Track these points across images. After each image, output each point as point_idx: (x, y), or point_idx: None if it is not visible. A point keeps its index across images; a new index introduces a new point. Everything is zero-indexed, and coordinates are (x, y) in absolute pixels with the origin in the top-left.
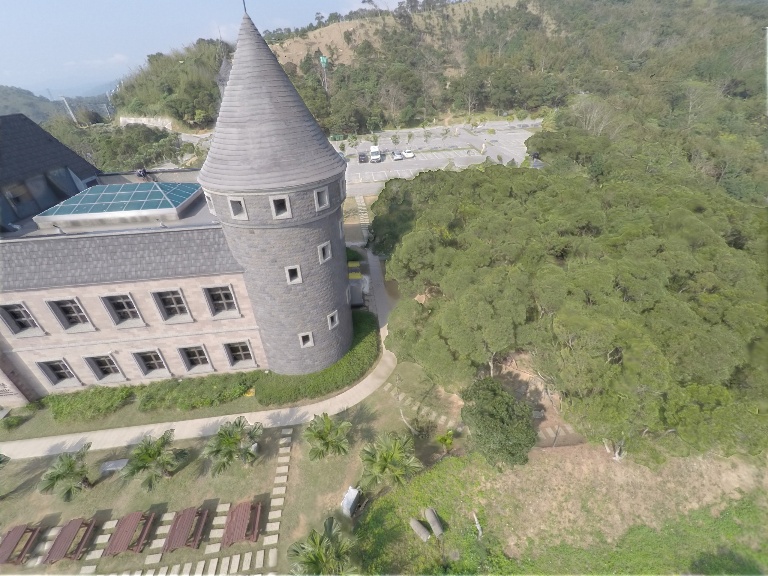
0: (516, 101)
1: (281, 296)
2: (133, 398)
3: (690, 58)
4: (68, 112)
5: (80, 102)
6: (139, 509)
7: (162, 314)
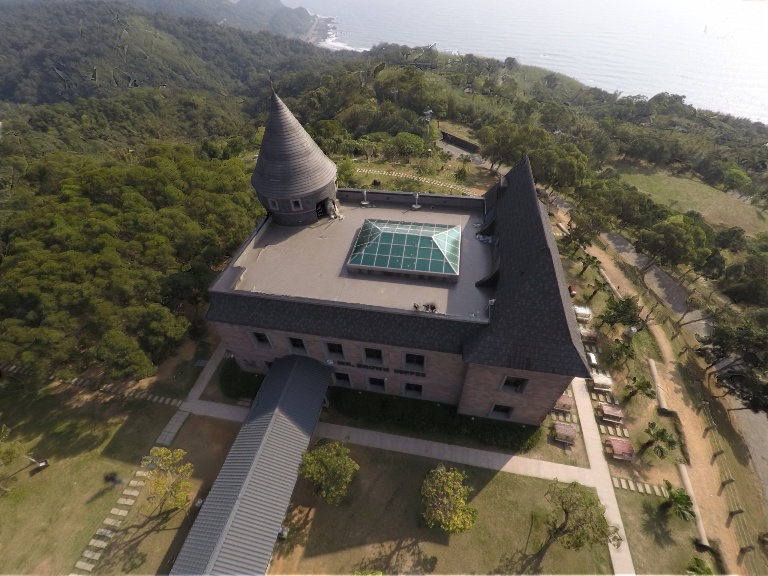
0: None
1: None
2: None
3: None
4: None
5: None
6: None
7: None
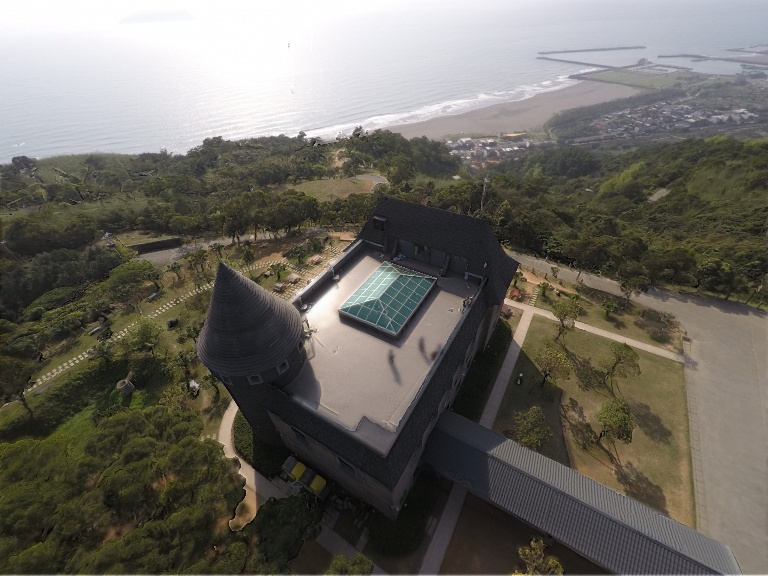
0: None
1: None
2: None
3: None
4: None
5: None
6: None
7: None
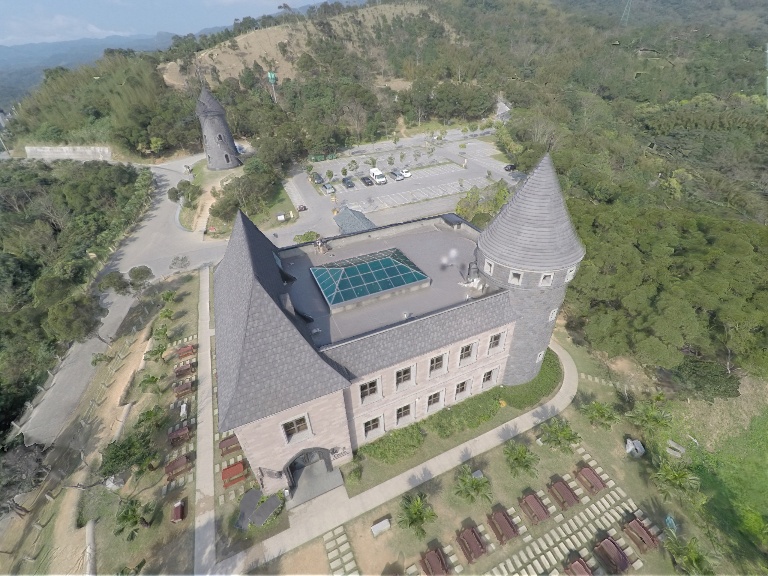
0: (456, 111)
1: (541, 330)
2: (423, 432)
3: (567, 67)
4: None
5: None
6: (517, 497)
7: None
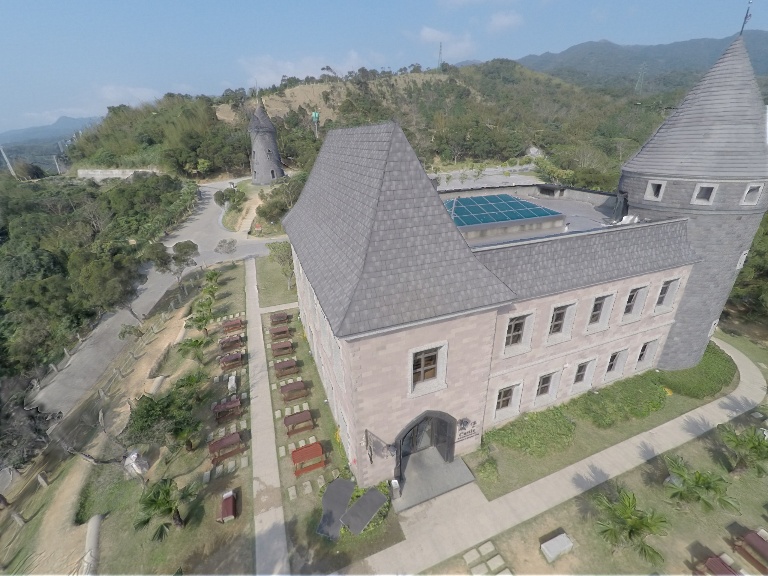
0: (492, 152)
1: (725, 282)
2: None
3: (593, 123)
4: (4, 164)
5: (21, 153)
6: (760, 514)
7: (623, 314)
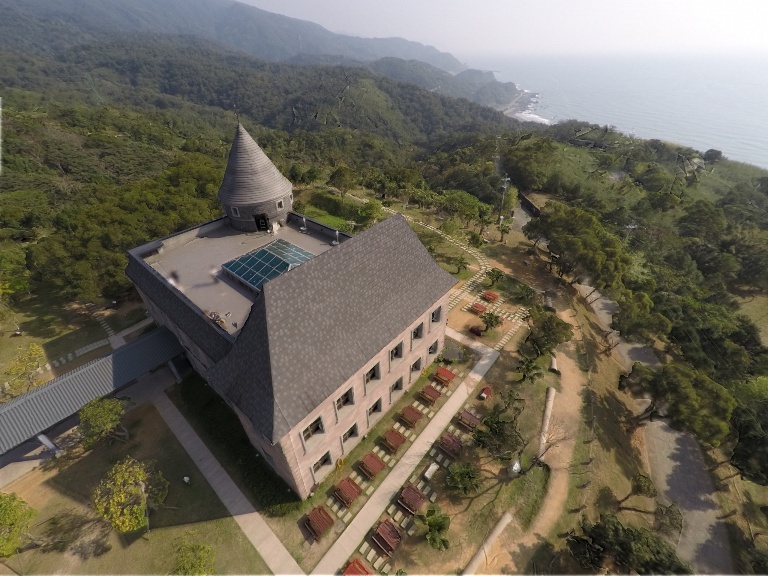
0: None
1: None
2: None
3: None
4: None
5: None
6: None
7: None
